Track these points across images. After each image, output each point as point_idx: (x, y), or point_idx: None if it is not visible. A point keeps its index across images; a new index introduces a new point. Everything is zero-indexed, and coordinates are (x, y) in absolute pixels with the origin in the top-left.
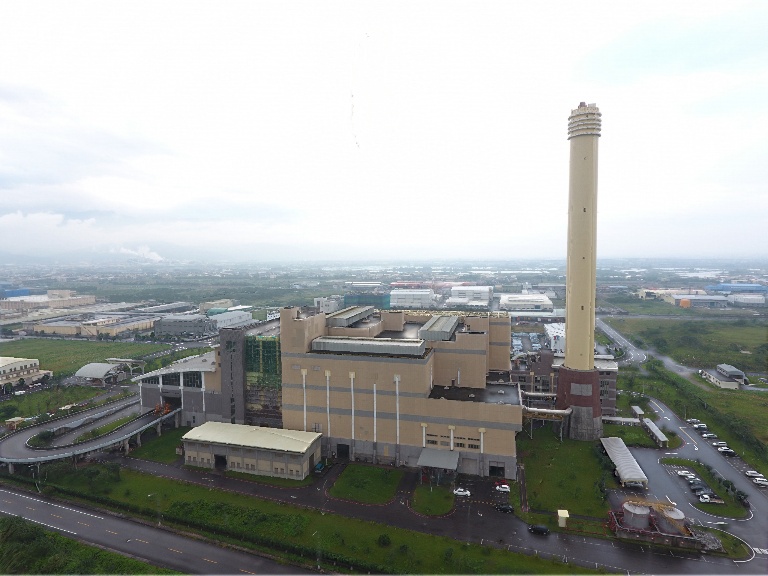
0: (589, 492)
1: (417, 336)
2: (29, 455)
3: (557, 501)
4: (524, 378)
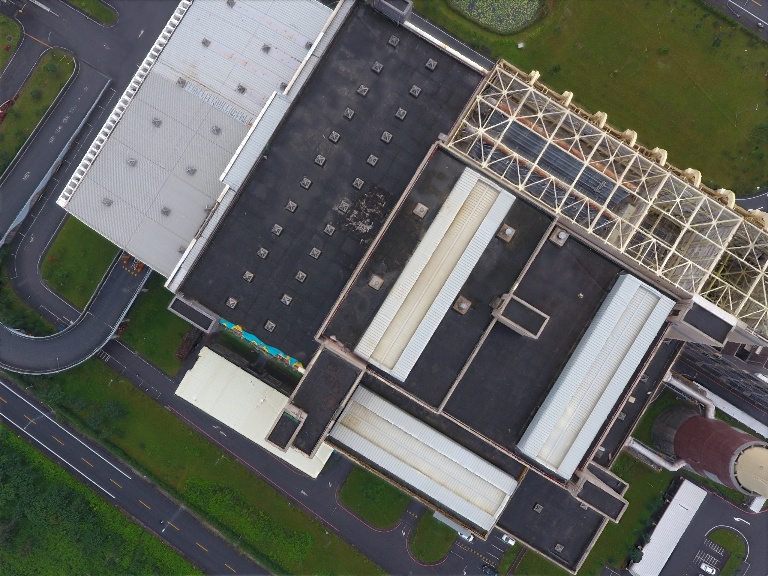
0: (585, 570)
1: (532, 393)
2: (7, 349)
3: (545, 575)
4: (701, 346)
